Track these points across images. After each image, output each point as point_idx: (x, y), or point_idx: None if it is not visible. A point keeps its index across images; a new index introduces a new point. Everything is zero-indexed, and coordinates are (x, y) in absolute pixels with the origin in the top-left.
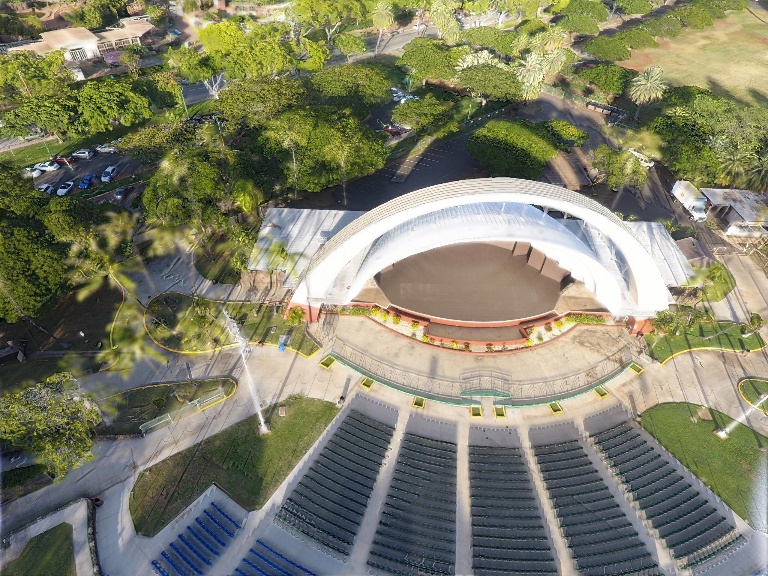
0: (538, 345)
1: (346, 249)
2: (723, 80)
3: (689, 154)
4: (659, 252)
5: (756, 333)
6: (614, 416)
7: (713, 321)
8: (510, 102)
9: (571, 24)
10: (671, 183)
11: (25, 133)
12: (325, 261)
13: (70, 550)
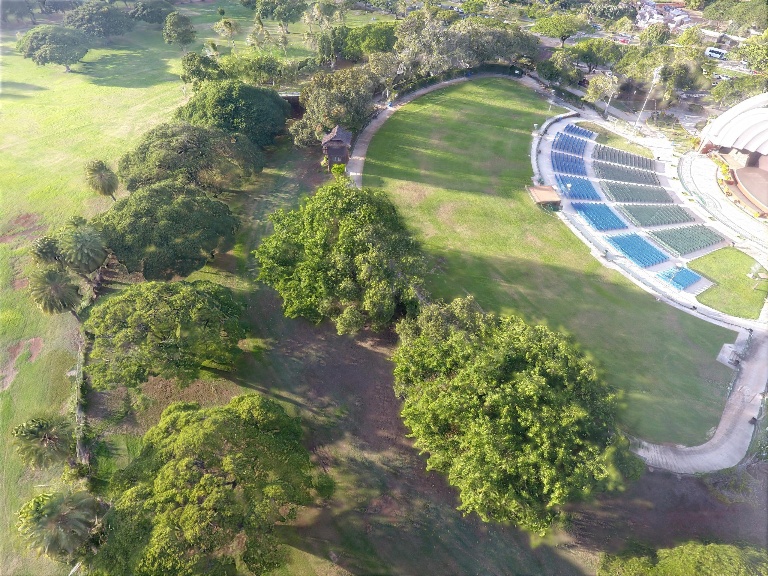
0: (759, 221)
1: (738, 107)
2: None
3: None
4: None
5: None
6: (725, 238)
7: None
8: None
9: None
10: None
11: (736, 58)
12: (727, 112)
13: (564, 113)
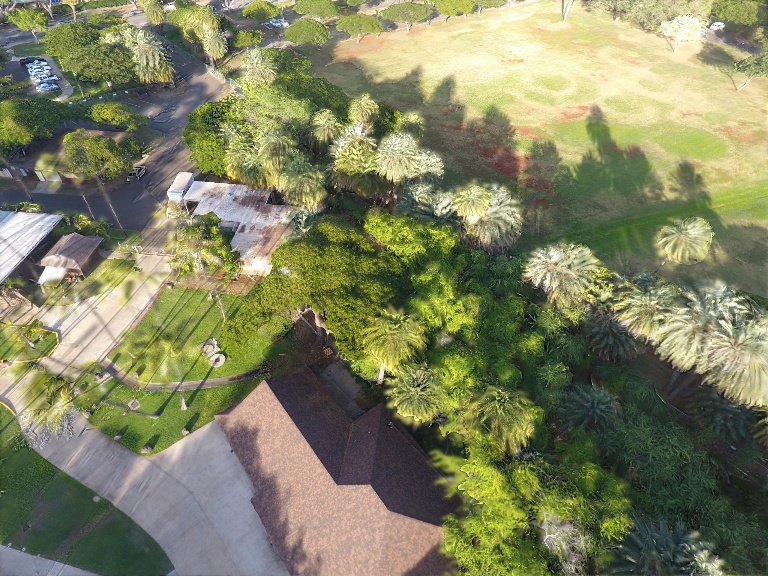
0: None
1: None
2: (429, 70)
3: (198, 143)
4: (2, 247)
5: (54, 342)
6: None
7: (24, 326)
8: (143, 84)
9: (302, 6)
10: (208, 175)
11: None
12: None
13: None
